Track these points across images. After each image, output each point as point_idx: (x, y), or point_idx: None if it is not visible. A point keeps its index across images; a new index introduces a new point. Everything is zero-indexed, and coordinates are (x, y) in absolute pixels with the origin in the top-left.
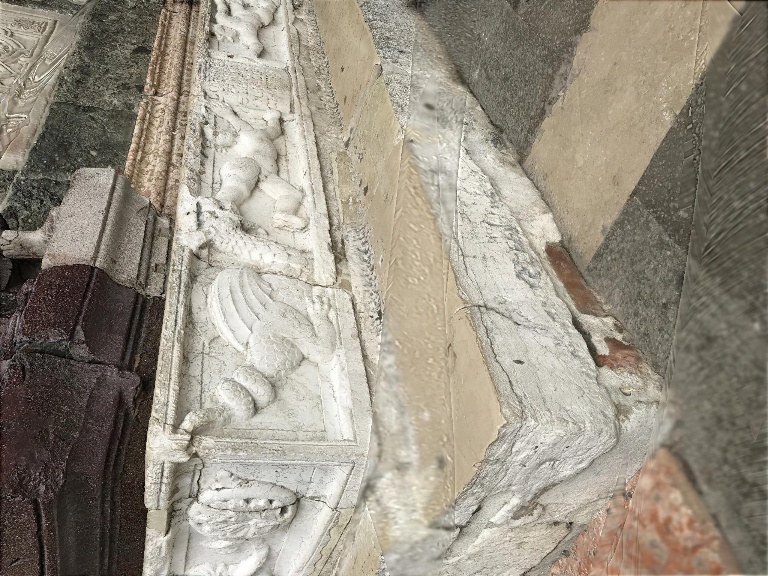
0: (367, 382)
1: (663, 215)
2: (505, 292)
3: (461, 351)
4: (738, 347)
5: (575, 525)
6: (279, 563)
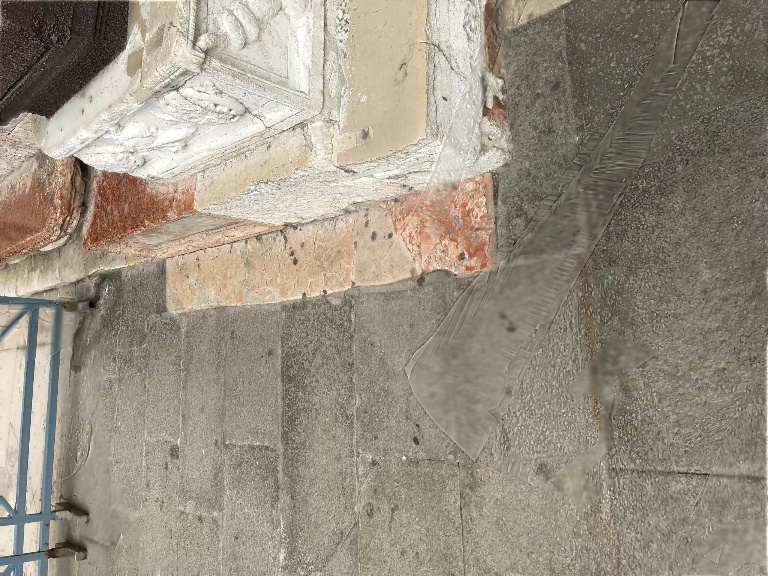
0: (324, 49)
1: (572, 37)
2: (453, 38)
3: (413, 74)
4: (584, 217)
5: (413, 189)
6: (196, 139)
